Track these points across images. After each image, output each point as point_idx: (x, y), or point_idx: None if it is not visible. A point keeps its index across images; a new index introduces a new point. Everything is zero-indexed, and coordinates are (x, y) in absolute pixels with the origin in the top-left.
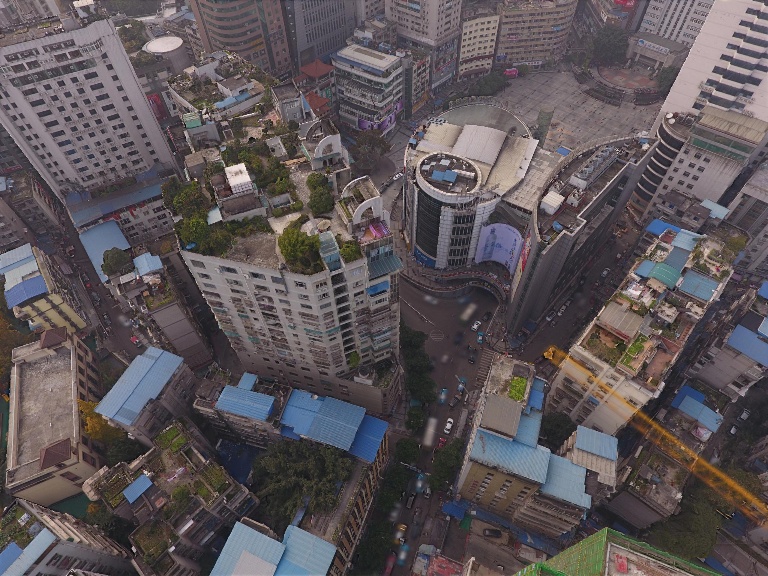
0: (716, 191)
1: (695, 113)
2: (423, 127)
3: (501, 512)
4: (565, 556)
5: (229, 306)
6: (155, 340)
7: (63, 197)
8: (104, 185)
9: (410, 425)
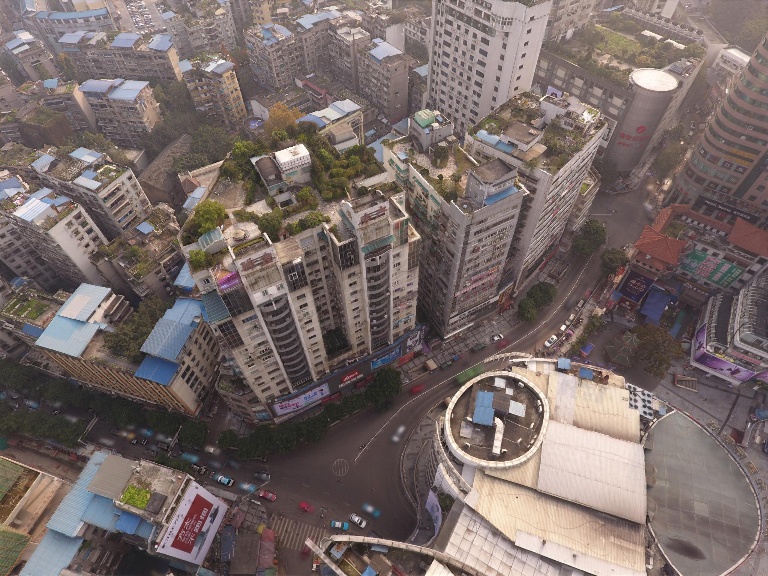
0: None
1: None
2: (608, 376)
3: None
4: None
5: None
6: None
7: None
8: None
9: None
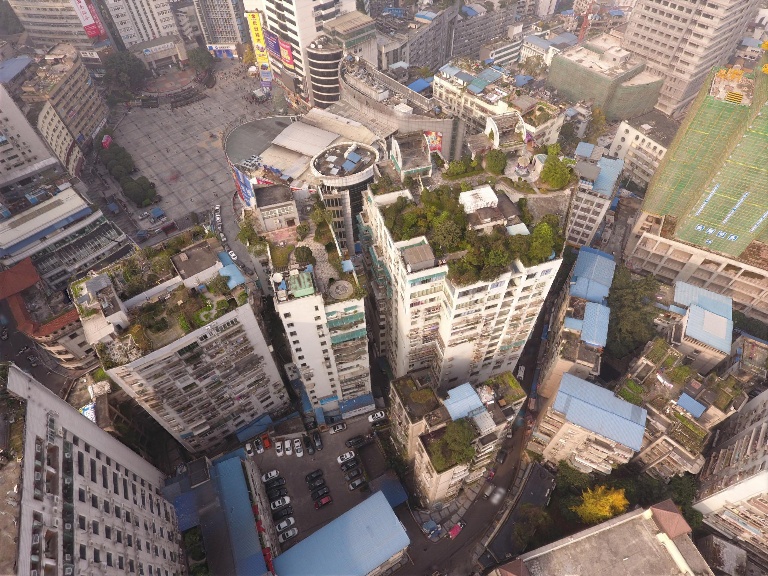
0: None
1: (320, 34)
2: None
3: None
4: (679, 152)
5: None
6: (482, 473)
7: None
8: None
9: None
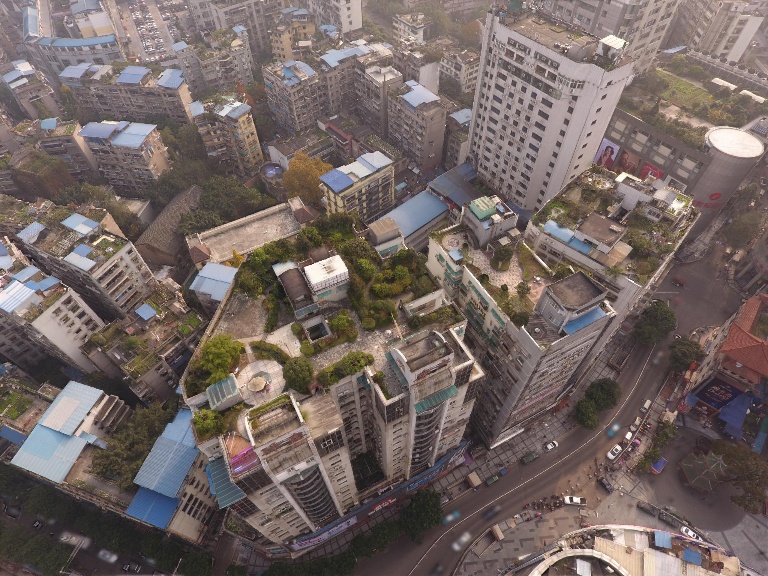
0: None
1: None
2: (721, 562)
3: None
4: None
5: None
6: None
7: (466, 161)
8: (488, 183)
9: (226, 570)
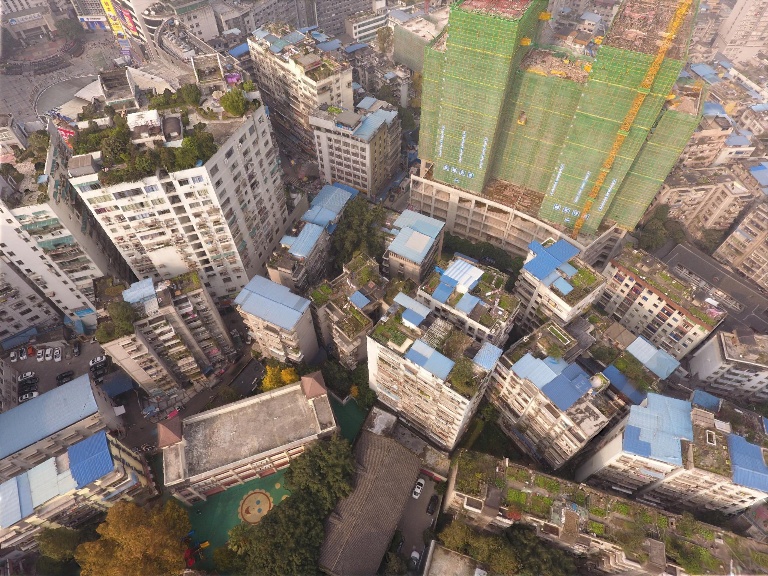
0: (214, 31)
1: (155, 2)
2: None
3: (384, 181)
4: (424, 100)
5: (235, 207)
6: (196, 364)
7: None
8: None
9: None
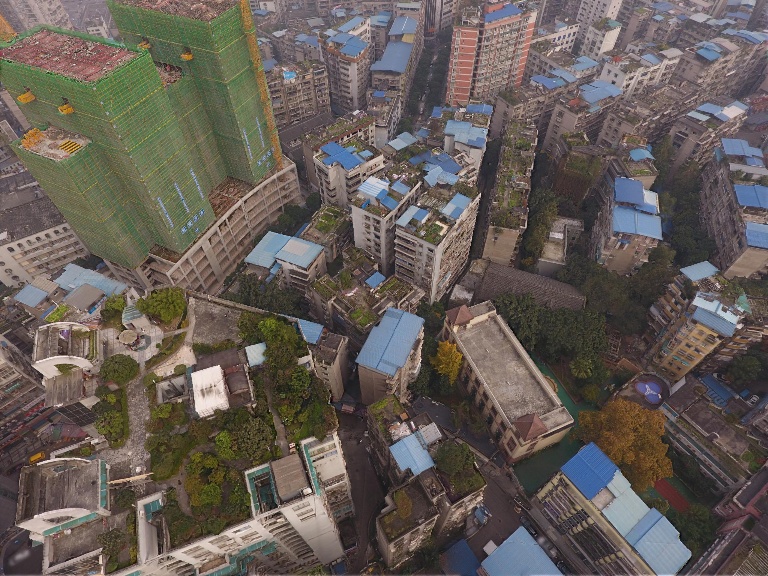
0: None
1: None
2: None
3: None
4: None
5: None
6: None
7: None
8: None
9: None
